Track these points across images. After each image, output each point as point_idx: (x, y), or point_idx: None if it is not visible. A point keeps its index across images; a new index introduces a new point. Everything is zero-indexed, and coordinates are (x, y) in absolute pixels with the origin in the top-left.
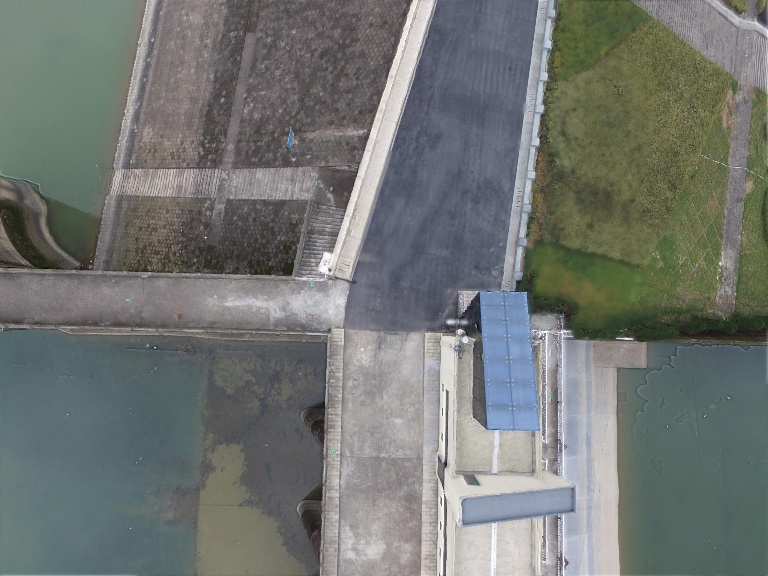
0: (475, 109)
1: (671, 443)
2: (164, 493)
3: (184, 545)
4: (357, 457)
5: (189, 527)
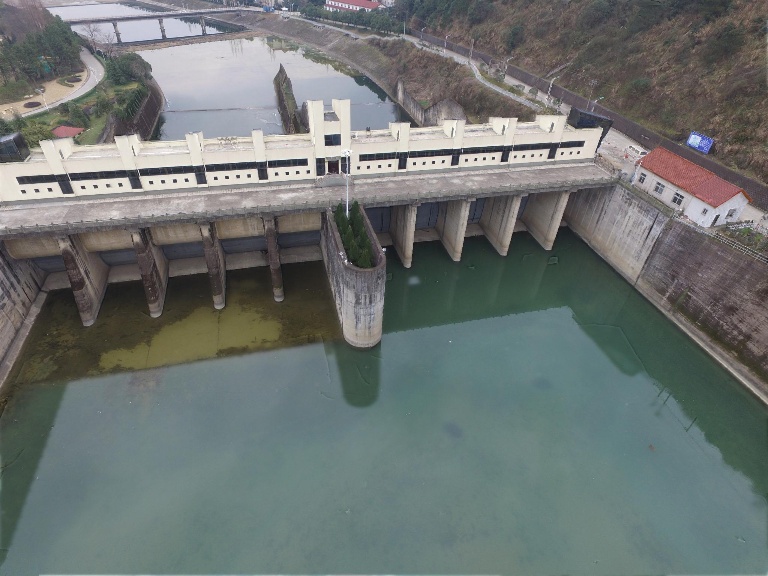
0: None
1: None
2: (133, 392)
3: (178, 373)
4: None
5: (163, 371)
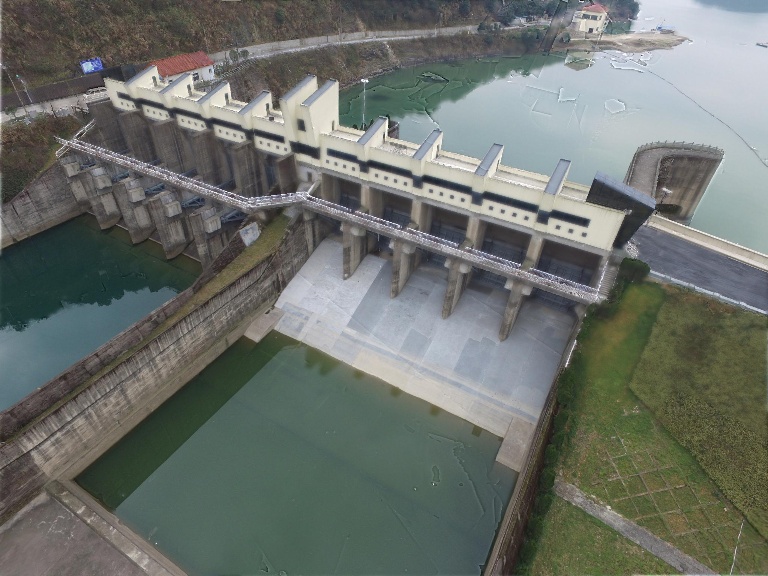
0: (764, 293)
1: (404, 477)
2: None
3: None
4: None
5: None
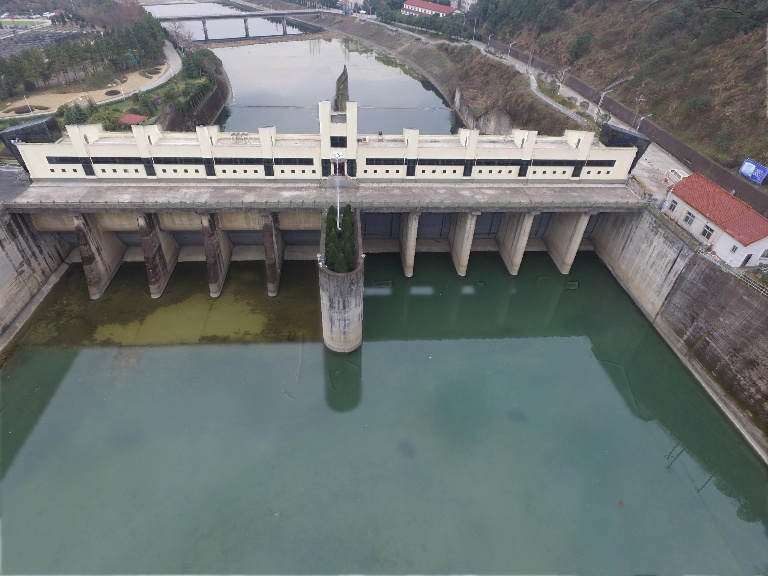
0: None
1: None
2: (114, 365)
3: None
4: (78, 201)
5: (146, 349)
